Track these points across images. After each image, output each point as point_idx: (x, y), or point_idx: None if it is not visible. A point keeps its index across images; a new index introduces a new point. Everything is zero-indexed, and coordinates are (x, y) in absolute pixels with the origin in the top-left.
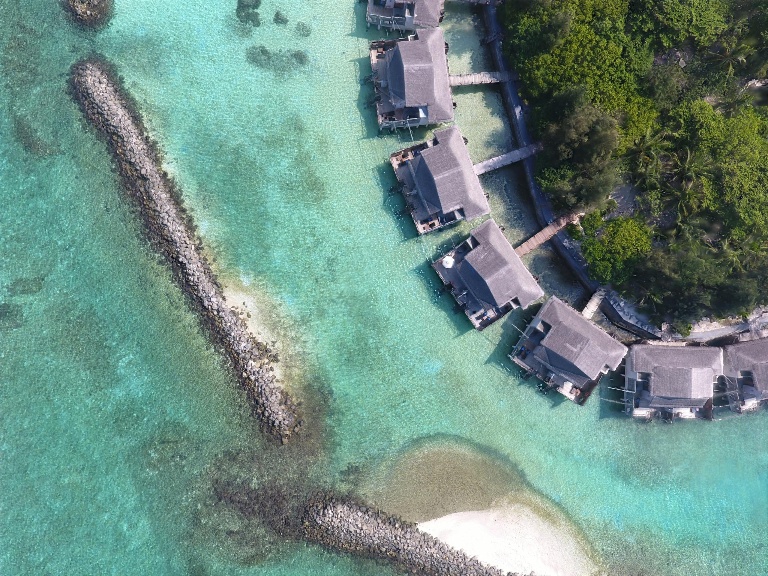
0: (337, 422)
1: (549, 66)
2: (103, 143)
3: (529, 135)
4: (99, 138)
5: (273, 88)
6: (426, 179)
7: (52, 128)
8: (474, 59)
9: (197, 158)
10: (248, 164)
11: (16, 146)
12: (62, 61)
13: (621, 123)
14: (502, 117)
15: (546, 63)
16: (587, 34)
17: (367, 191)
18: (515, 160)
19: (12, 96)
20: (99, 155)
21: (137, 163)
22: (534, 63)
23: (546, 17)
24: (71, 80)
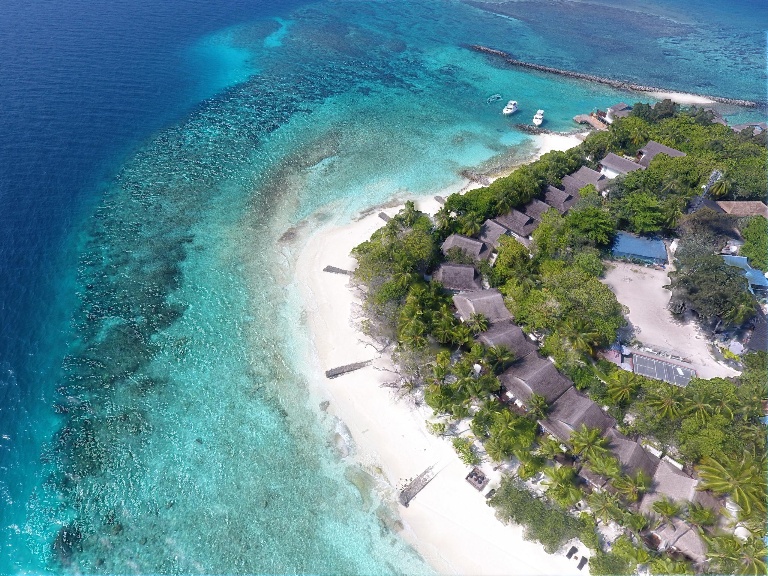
0: (767, 119)
1: None
2: None
3: None
4: None
5: None
6: None
7: None
8: None
9: None
10: None
11: None
12: None
13: None
14: None
15: None
16: None
17: None
18: None
19: None
20: None
21: None
22: None
23: None
24: None
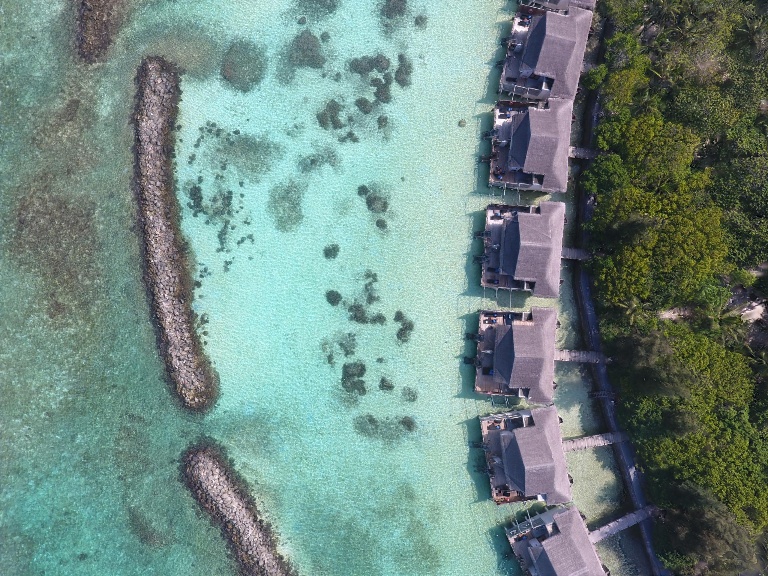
0: None
1: (671, 451)
2: (217, 529)
3: (644, 496)
4: (213, 524)
5: (382, 457)
6: (549, 570)
7: (166, 517)
8: (583, 412)
9: (310, 536)
10: (361, 537)
11: (132, 539)
12: (172, 447)
13: (748, 513)
14: (613, 469)
15: (668, 449)
16: (711, 423)
17: (481, 556)
18: (632, 524)
19: (125, 488)
20: (214, 541)
21: (254, 554)
22: (655, 447)
23: (666, 402)
24: (182, 468)
